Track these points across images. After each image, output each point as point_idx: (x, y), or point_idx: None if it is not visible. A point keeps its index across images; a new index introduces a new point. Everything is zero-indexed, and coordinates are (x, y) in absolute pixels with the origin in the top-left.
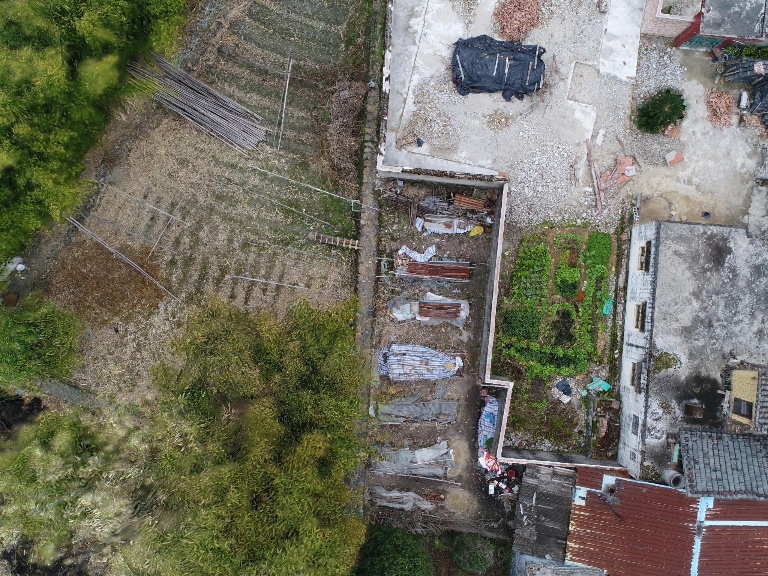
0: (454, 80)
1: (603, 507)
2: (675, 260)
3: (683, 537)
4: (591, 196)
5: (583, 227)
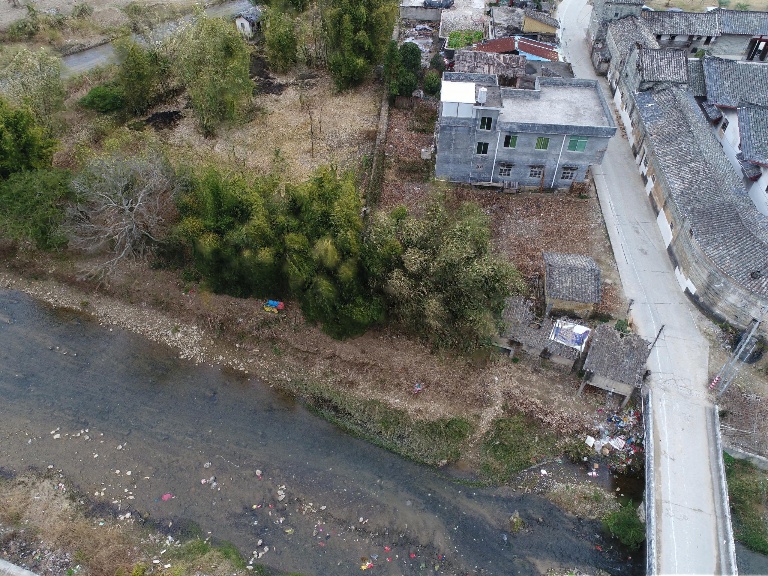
0: (425, 5)
1: (483, 45)
2: (498, 11)
3: (511, 43)
4: (473, 23)
5: (472, 31)
